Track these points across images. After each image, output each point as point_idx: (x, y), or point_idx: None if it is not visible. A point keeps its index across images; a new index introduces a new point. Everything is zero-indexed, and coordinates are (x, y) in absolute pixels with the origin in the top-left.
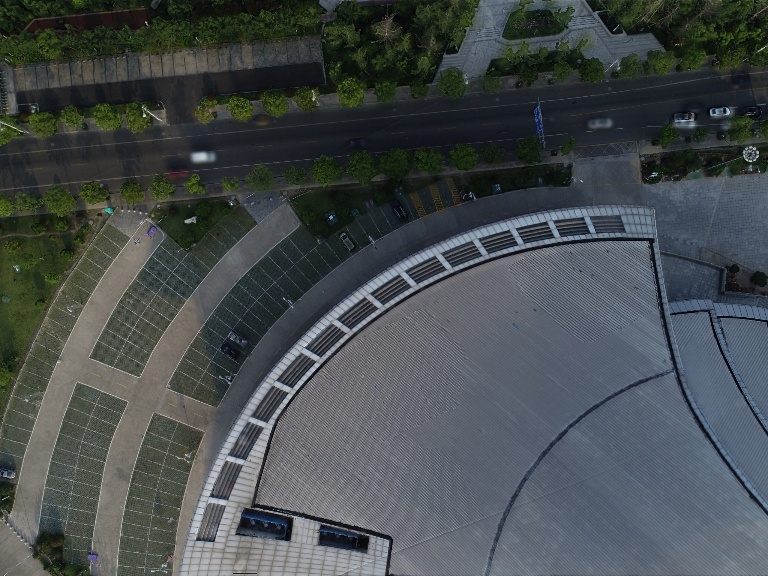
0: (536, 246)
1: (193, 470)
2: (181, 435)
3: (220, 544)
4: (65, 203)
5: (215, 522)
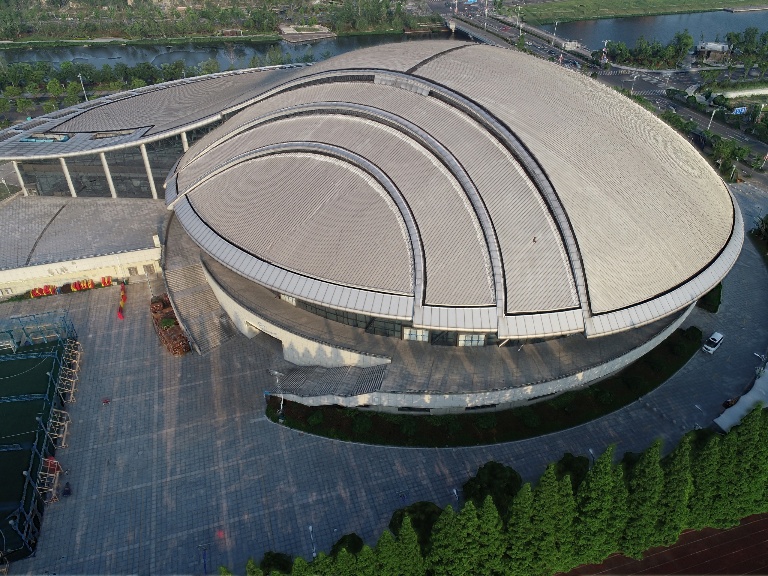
0: (298, 66)
1: (0, 203)
2: (5, 189)
3: (2, 144)
4: (4, 102)
5: (7, 138)
